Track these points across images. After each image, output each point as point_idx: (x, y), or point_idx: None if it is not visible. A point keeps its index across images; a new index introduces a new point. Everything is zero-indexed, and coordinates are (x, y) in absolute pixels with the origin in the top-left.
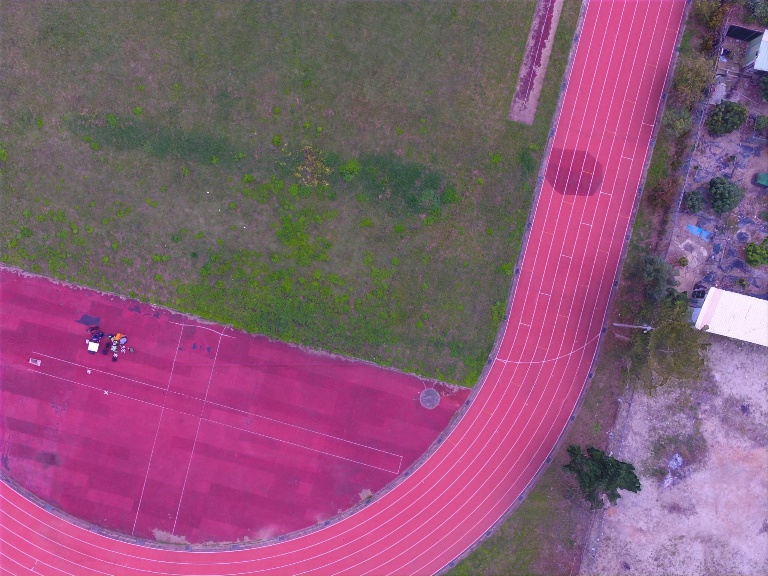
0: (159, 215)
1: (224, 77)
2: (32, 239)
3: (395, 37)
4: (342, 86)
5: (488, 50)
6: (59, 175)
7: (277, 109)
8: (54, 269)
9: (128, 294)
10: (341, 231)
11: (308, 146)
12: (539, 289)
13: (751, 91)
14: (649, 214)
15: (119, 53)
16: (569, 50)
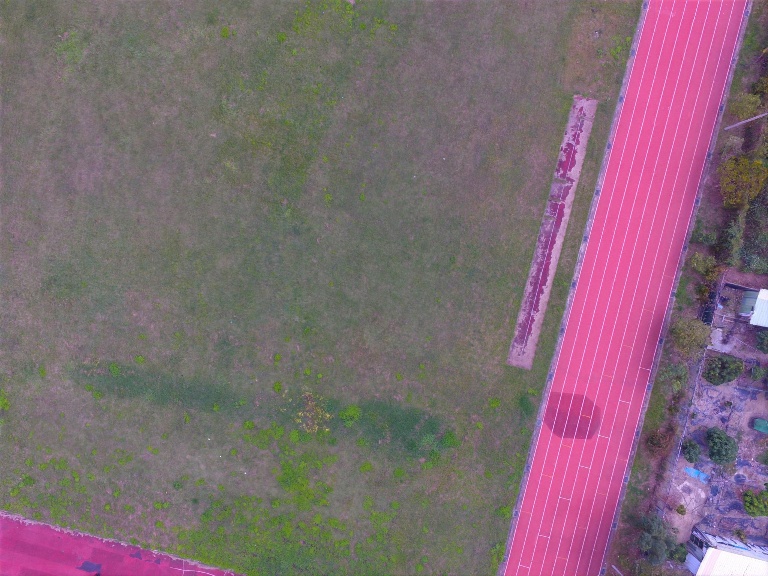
0: (160, 462)
1: (225, 325)
2: (34, 487)
3: (395, 284)
4: (342, 333)
5: (487, 297)
6: (61, 423)
7: (278, 357)
8: (56, 517)
9: (129, 541)
10: (341, 476)
11: (308, 392)
12: (538, 531)
13: (747, 336)
14: (647, 457)
15: (121, 303)
16: (567, 296)
